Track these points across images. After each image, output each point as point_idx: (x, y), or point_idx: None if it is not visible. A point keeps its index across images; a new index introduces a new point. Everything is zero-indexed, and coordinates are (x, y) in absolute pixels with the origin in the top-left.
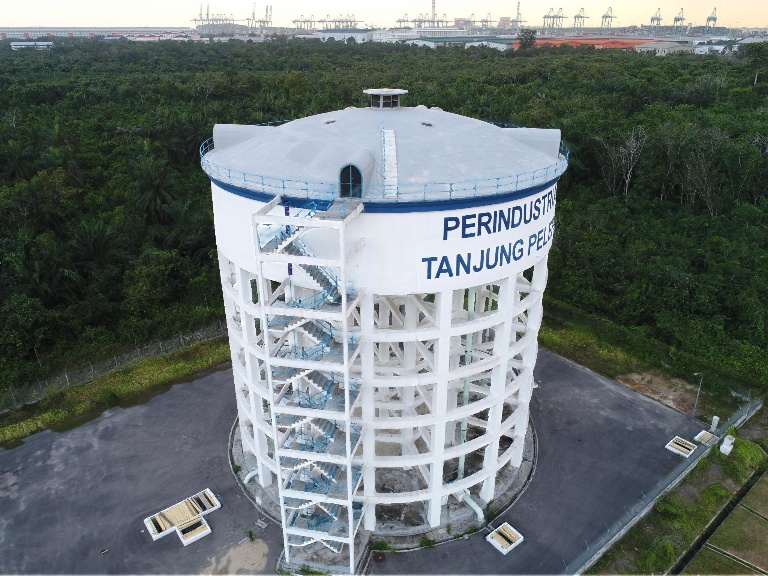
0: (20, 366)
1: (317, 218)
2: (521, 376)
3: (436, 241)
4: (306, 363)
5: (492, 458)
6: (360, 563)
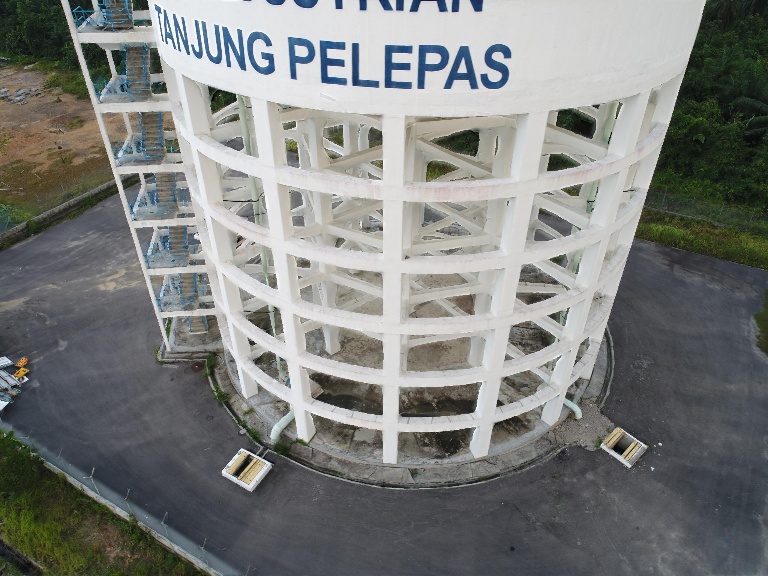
0: None
1: None
2: (347, 313)
3: None
4: None
5: (292, 383)
6: (185, 353)
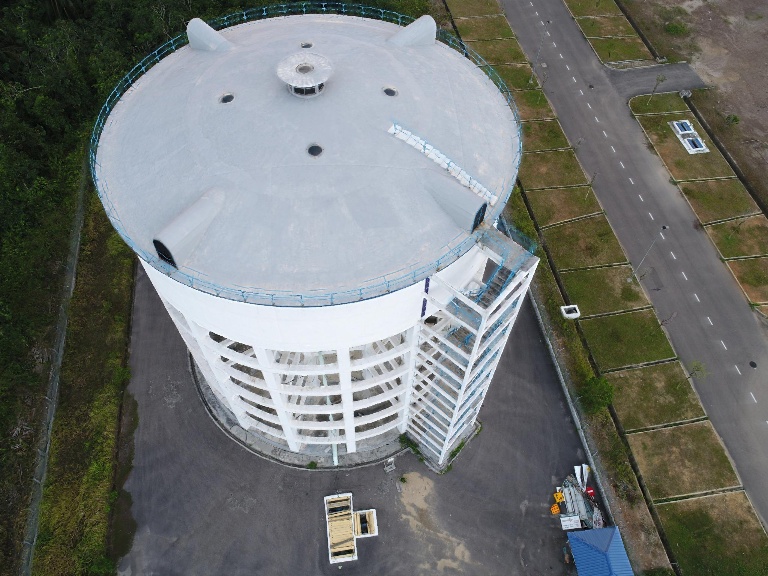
0: None
1: (523, 272)
2: None
3: None
4: None
5: None
6: None
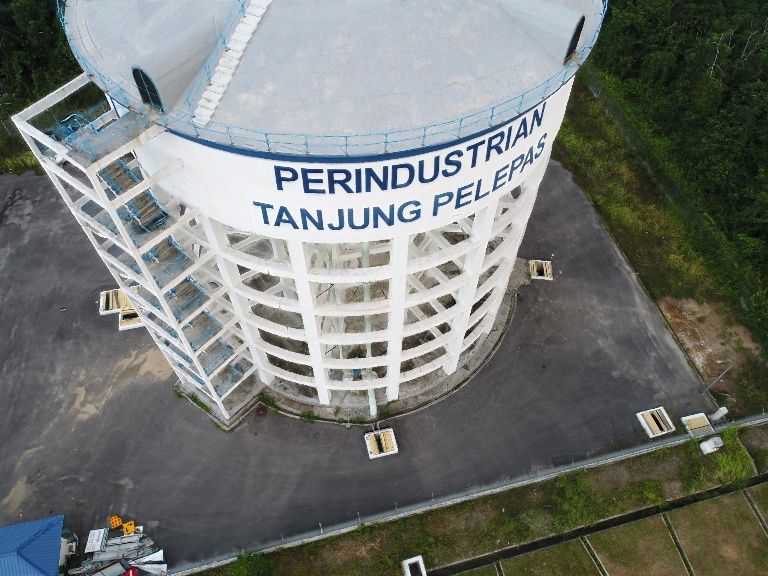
0: None
1: (66, 150)
2: (441, 315)
3: (268, 188)
4: (125, 271)
5: (391, 375)
6: (241, 410)
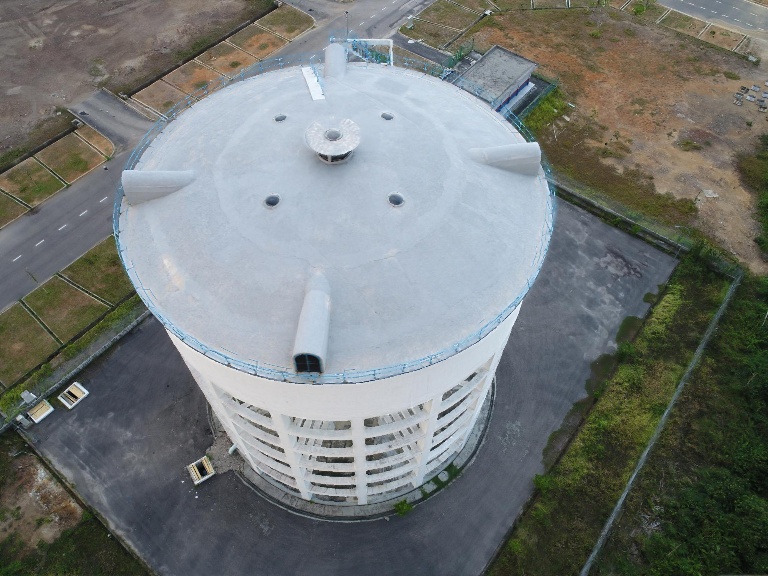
0: (762, 379)
1: None
2: None
3: None
4: None
5: None
6: None
